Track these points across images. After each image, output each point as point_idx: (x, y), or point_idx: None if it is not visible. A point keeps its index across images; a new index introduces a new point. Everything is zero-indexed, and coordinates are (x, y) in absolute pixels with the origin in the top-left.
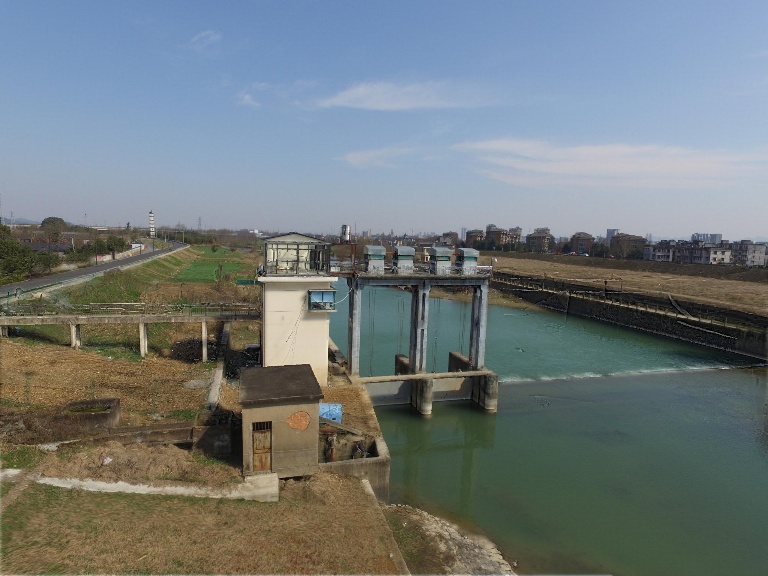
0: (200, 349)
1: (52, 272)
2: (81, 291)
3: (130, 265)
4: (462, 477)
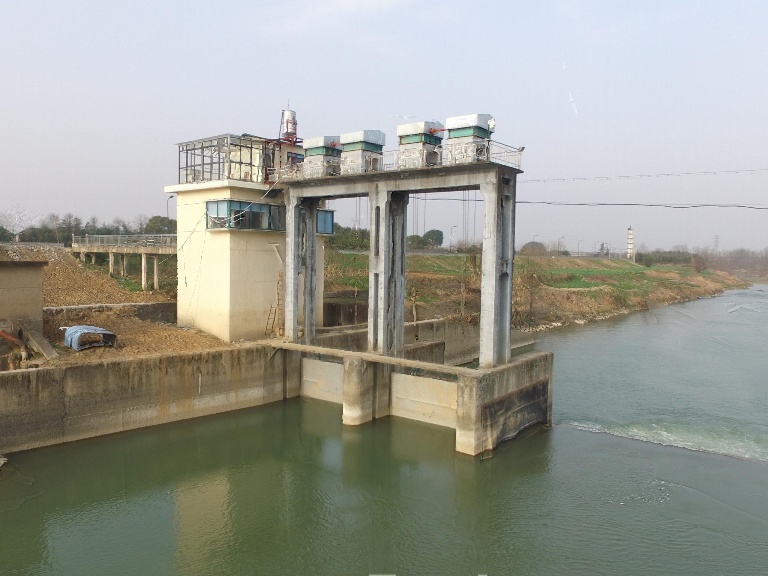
0: None
1: None
2: None
3: None
4: None
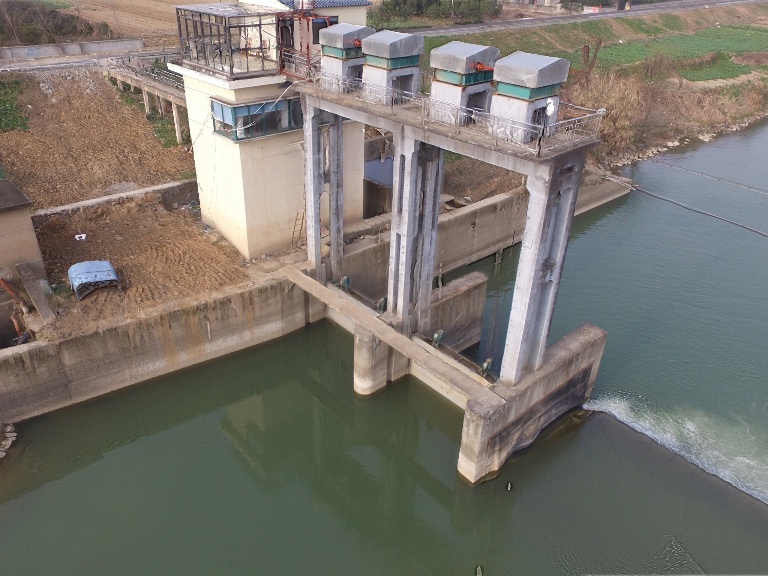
0: None
1: (394, 27)
2: None
3: (509, 26)
4: None
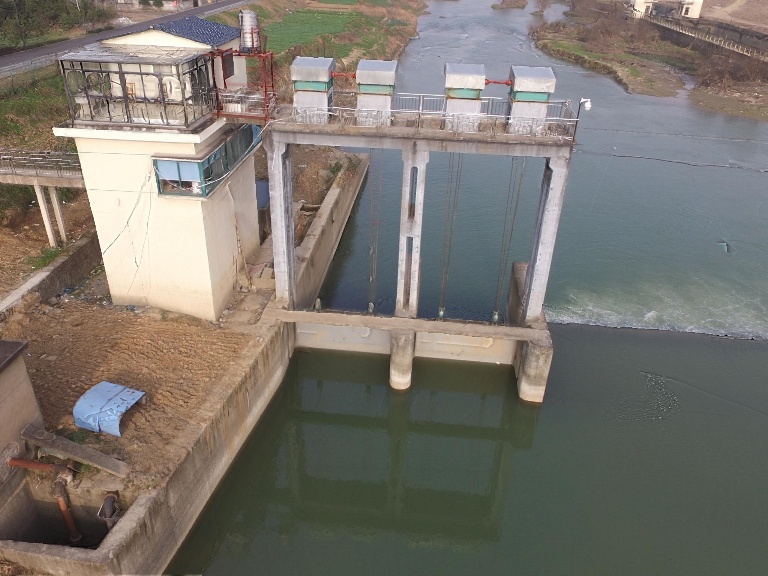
0: None
1: (34, 44)
2: (6, 88)
3: None
4: (492, 469)
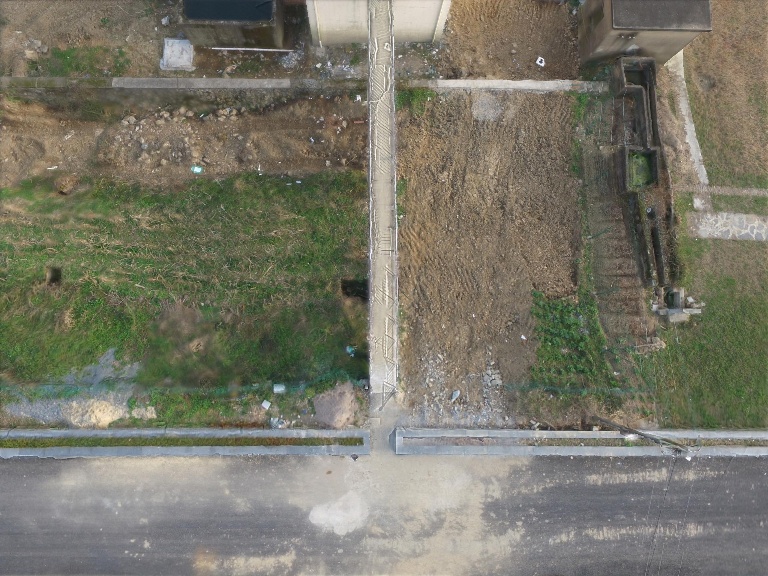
0: (247, 131)
1: None
2: None
3: None
4: None
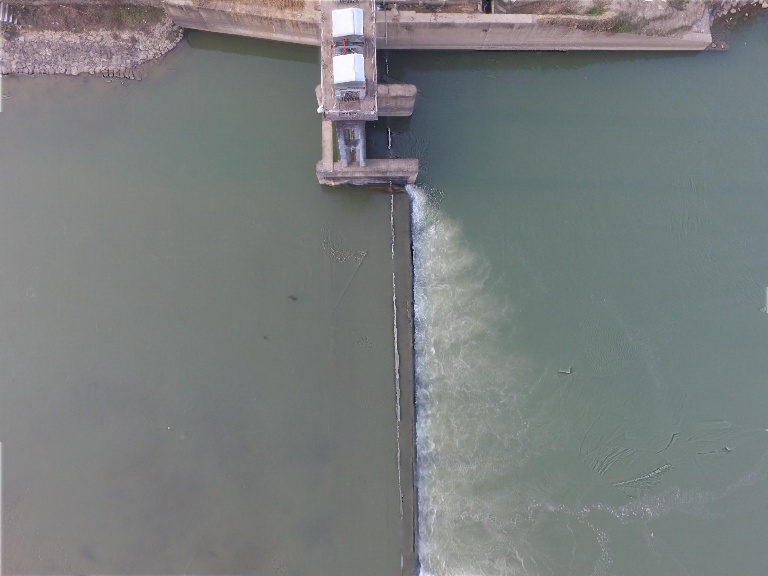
0: None
1: None
2: None
3: None
4: None
